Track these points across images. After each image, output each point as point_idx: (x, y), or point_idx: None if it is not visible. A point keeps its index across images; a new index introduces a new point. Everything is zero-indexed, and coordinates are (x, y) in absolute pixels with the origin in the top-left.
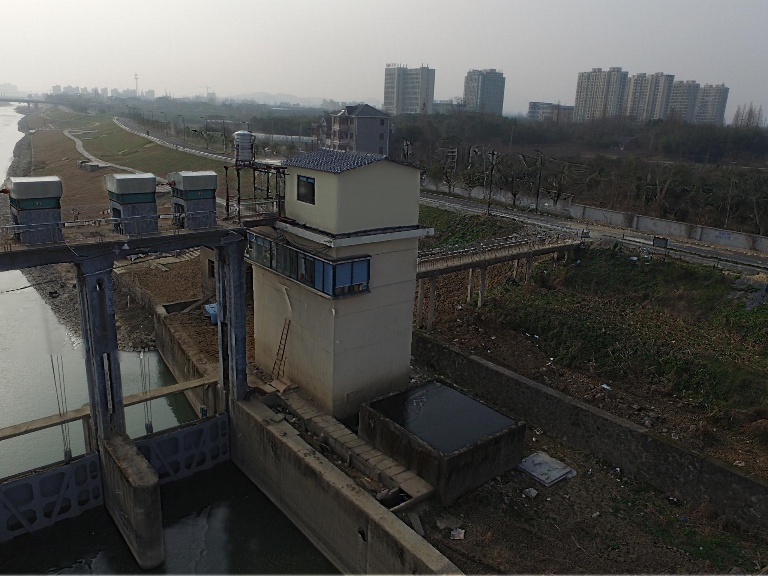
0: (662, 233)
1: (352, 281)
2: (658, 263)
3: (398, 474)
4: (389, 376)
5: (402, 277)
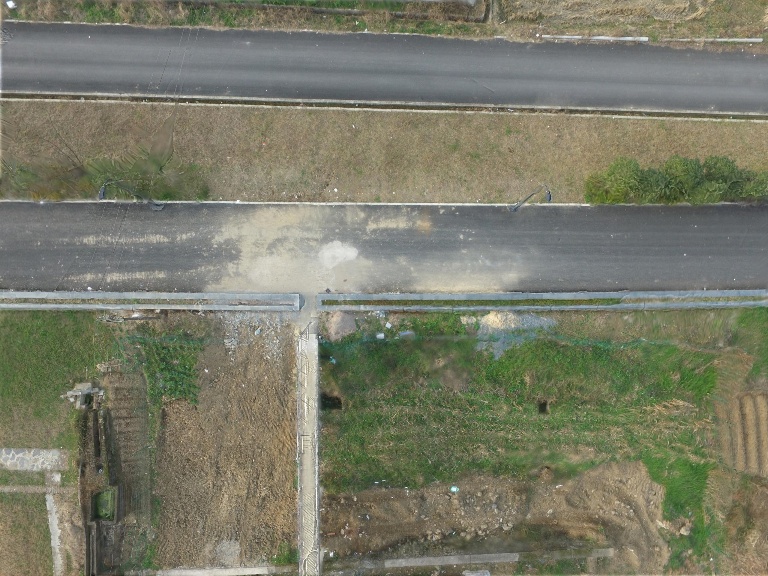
0: (243, 3)
1: None
2: None
3: None
4: None
5: None
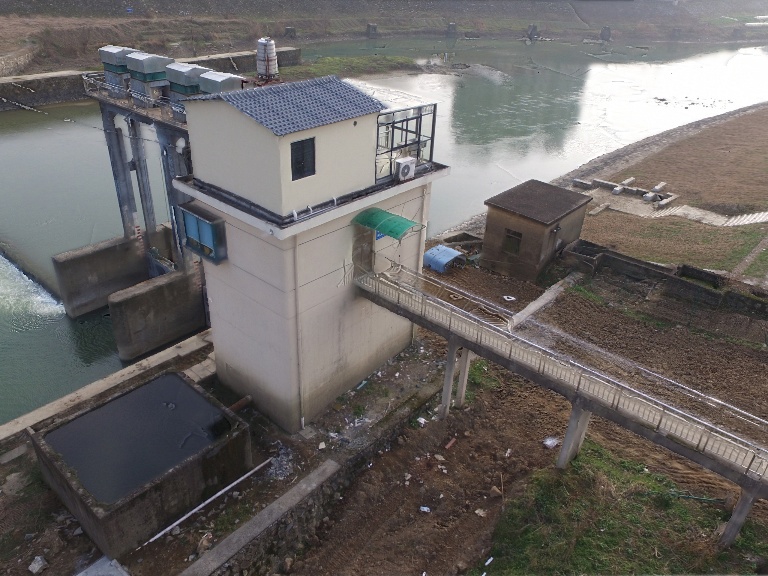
0: None
1: None
2: None
3: None
4: None
5: None
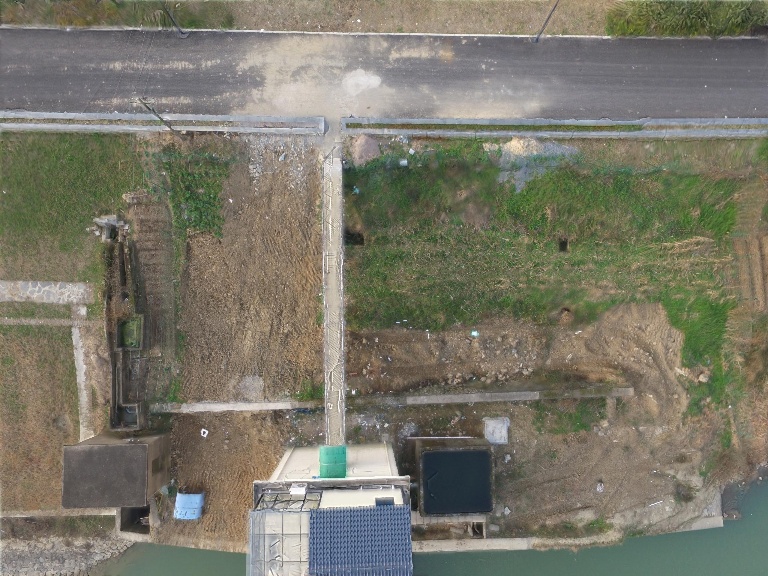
0: None
1: None
2: (430, 164)
3: (465, 517)
4: None
5: None
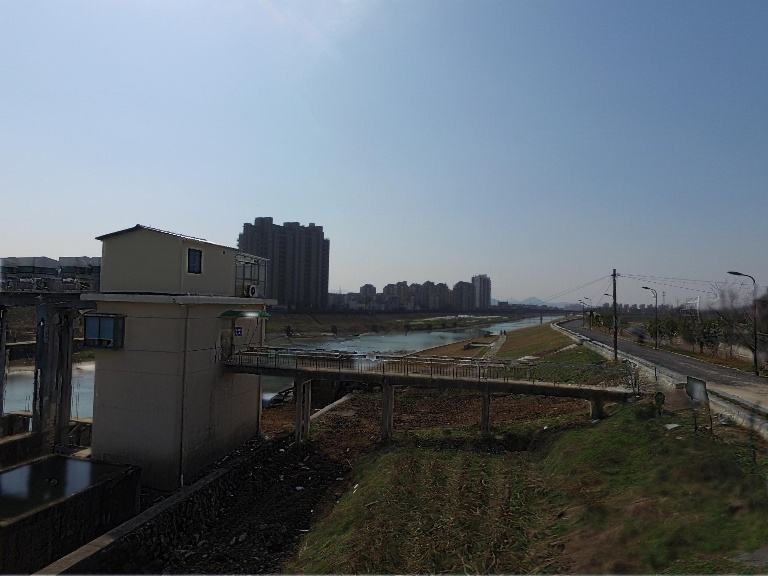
0: None
1: (100, 335)
2: (688, 438)
3: None
4: (149, 455)
5: (162, 346)
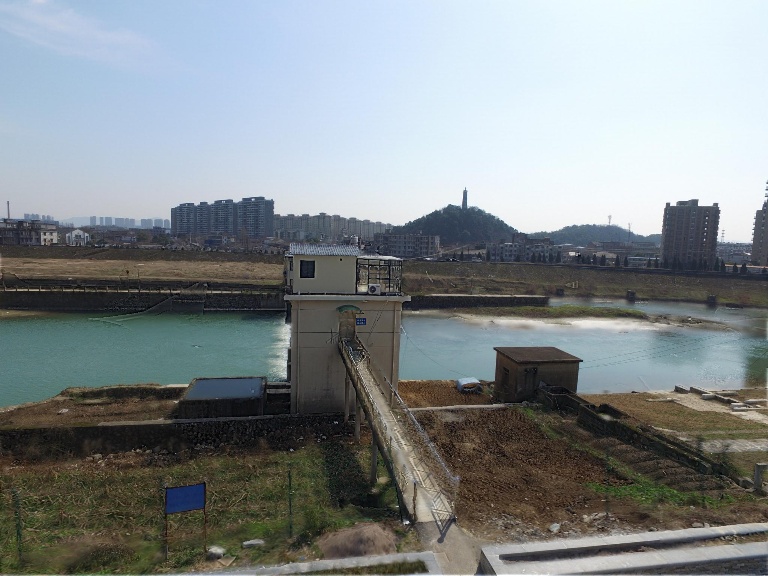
0: None
1: None
2: (180, 543)
3: None
4: None
5: None
